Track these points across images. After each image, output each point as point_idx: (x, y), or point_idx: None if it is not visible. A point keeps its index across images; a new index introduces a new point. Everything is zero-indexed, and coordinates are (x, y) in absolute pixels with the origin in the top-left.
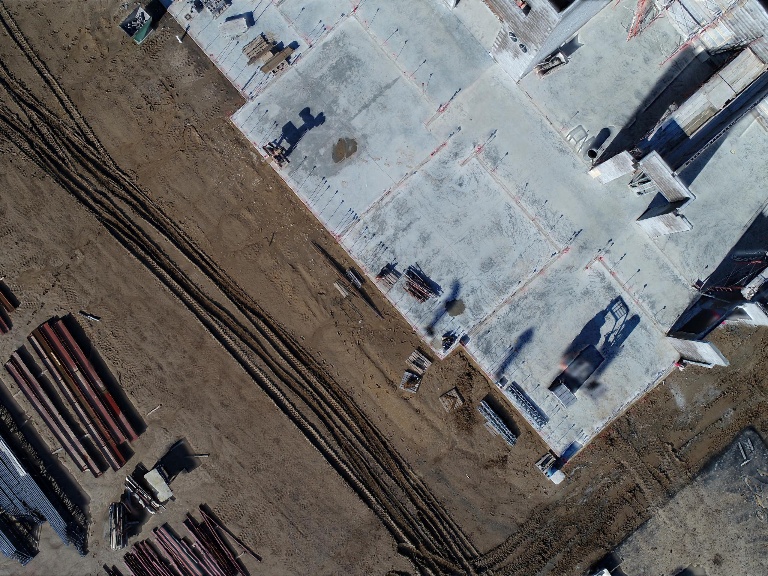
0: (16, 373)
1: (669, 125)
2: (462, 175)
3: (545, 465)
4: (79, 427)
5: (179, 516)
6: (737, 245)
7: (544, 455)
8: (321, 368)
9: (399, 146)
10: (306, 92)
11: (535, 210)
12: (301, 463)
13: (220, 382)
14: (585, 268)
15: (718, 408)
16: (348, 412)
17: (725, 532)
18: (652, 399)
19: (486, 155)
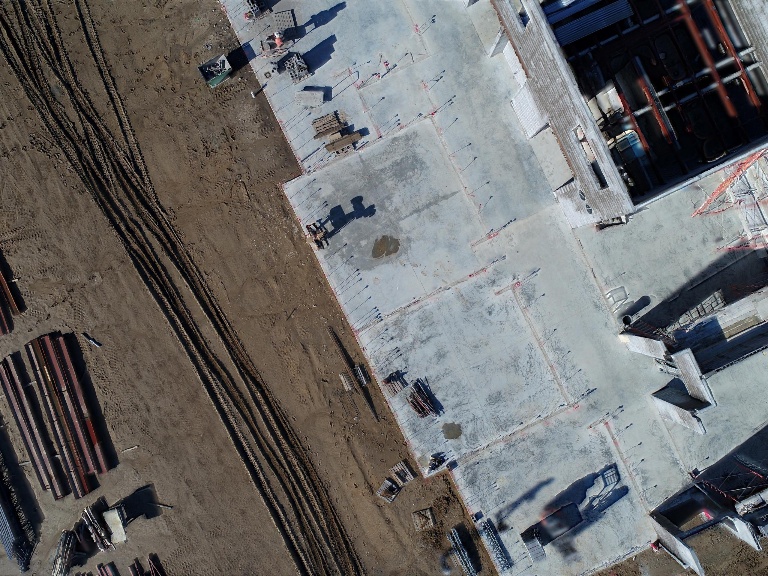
0: (5, 377)
1: (710, 322)
2: (494, 304)
3: None
4: (52, 446)
5: (127, 559)
6: (743, 445)
7: None
8: (304, 453)
9: (440, 258)
10: (364, 181)
11: (556, 357)
12: (260, 540)
13: (202, 439)
14: (589, 427)
15: None
16: (319, 503)
17: None
18: (618, 571)
19: (523, 290)
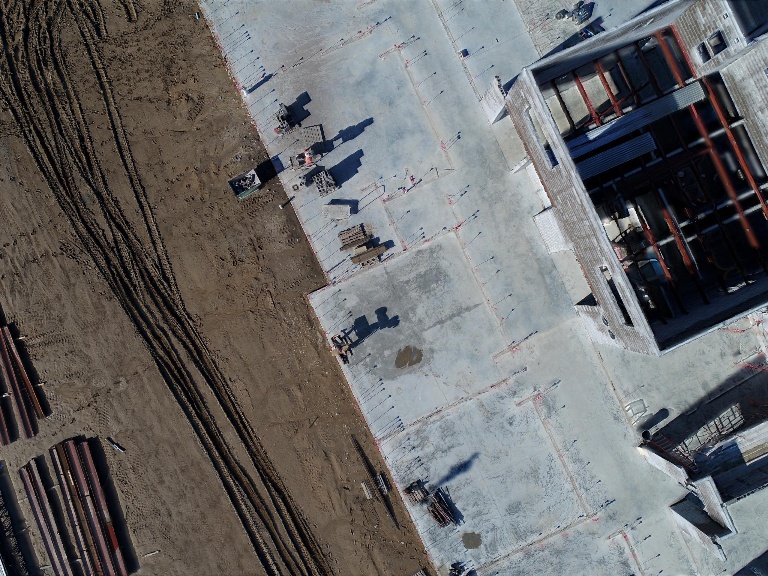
0: (28, 480)
1: (730, 446)
2: (515, 415)
3: None
4: (73, 550)
5: None
6: (760, 558)
7: None
8: (325, 560)
9: (462, 369)
10: (388, 292)
11: (575, 468)
12: None
13: (223, 545)
14: (608, 538)
15: None
16: None
17: None
18: None
19: (543, 402)
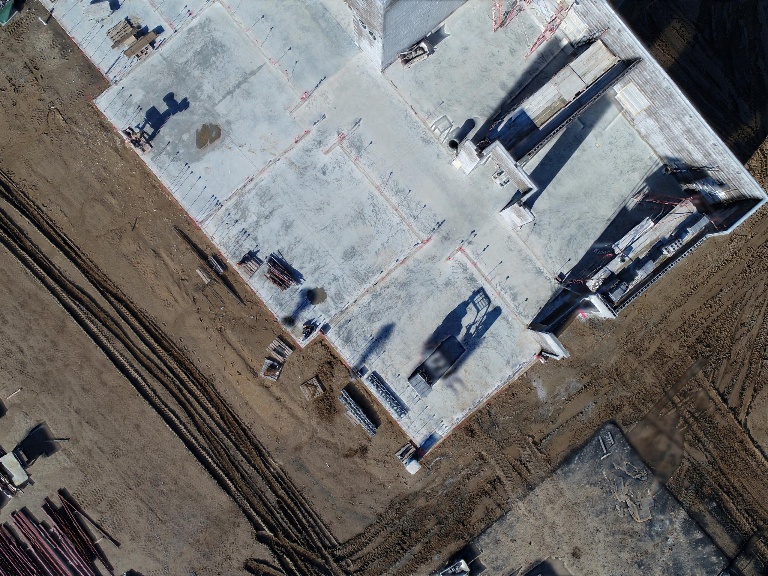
0: None
1: (519, 116)
2: (326, 163)
3: (405, 455)
4: None
5: (38, 500)
6: (600, 238)
7: (404, 445)
8: (182, 354)
9: (263, 133)
10: (170, 77)
11: (398, 200)
12: (161, 449)
13: (81, 366)
14: (448, 259)
15: (579, 401)
16: (209, 399)
17: (584, 525)
18: (513, 391)
19: (350, 144)
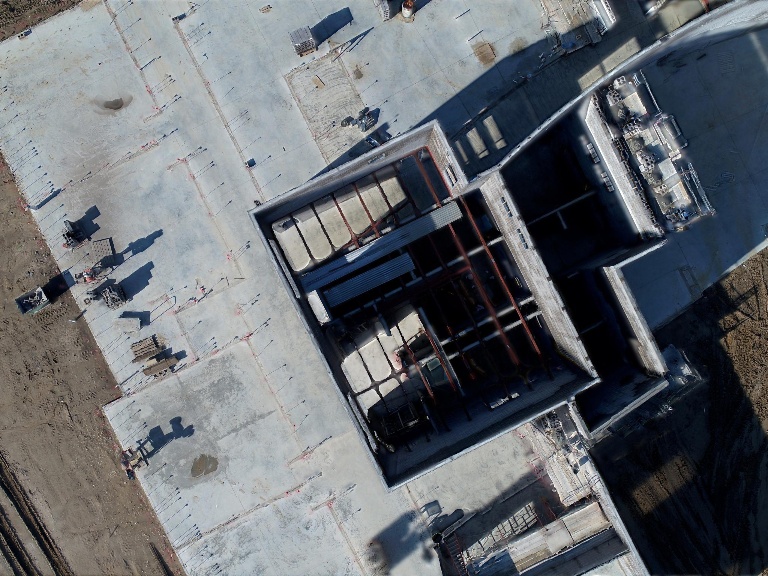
0: None
1: (503, 556)
2: (311, 519)
3: None
4: None
5: None
6: None
7: None
8: None
9: (258, 476)
10: (182, 402)
11: (373, 571)
12: None
13: None
14: None
15: None
16: None
17: None
18: None
19: (339, 506)
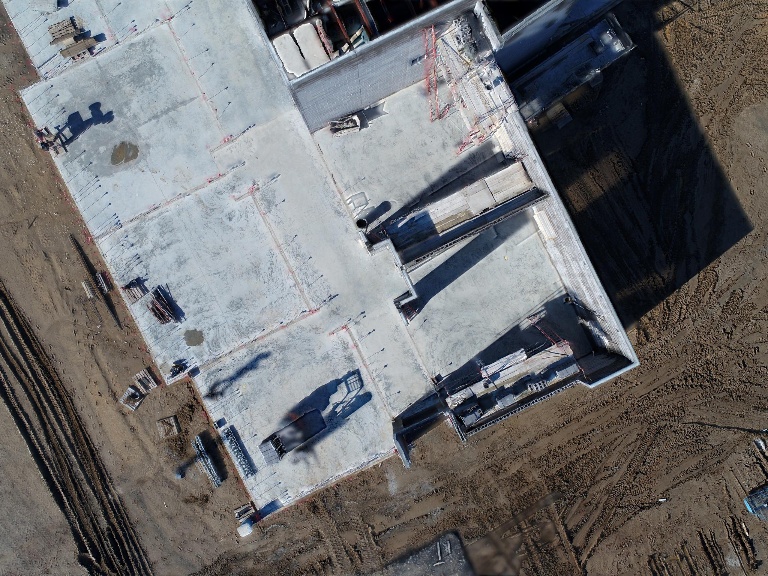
0: None
1: (423, 217)
2: (234, 210)
3: (243, 514)
4: None
5: None
6: (486, 350)
7: (245, 504)
8: (49, 362)
9: (180, 165)
10: (101, 87)
11: (297, 263)
12: (6, 449)
13: None
14: (331, 333)
15: (427, 504)
16: (64, 412)
17: None
18: (365, 478)
19: (263, 196)
